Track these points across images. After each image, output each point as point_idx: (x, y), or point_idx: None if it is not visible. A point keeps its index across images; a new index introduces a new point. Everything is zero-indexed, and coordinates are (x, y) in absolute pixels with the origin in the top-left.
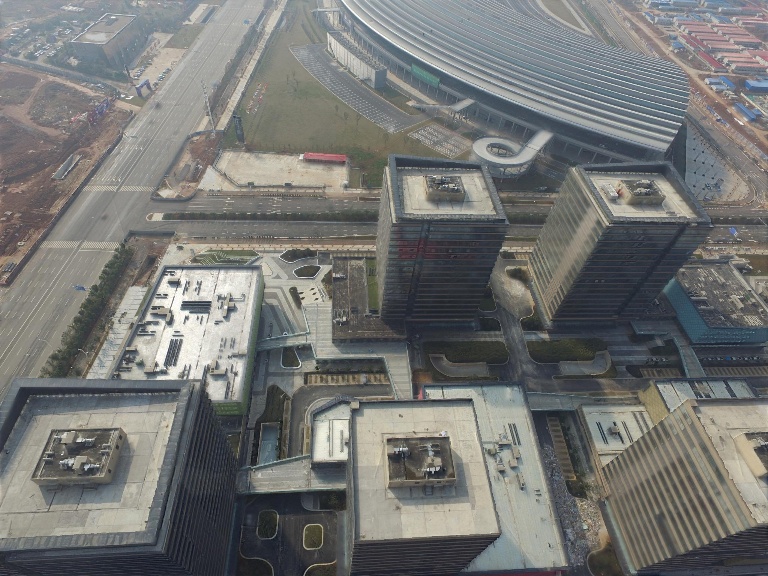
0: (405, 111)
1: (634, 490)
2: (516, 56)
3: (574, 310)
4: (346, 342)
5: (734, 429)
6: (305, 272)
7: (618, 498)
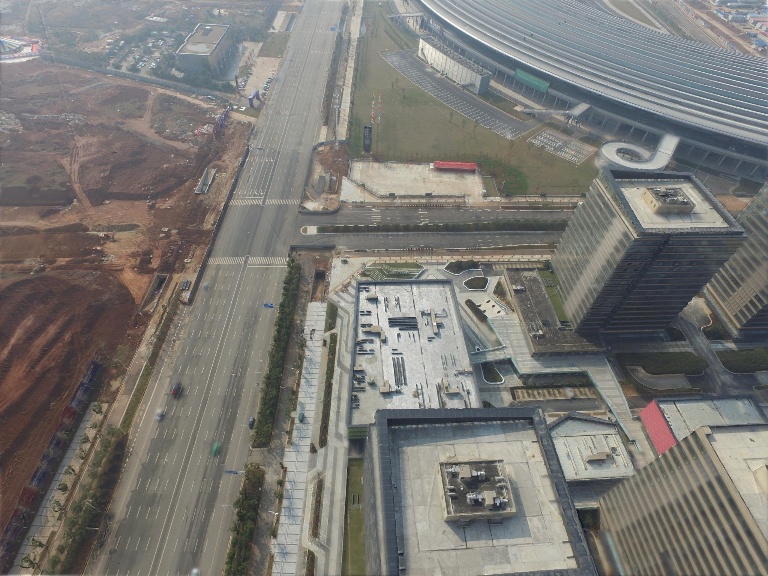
0: (516, 117)
1: None
2: (626, 59)
3: (766, 319)
4: (545, 356)
5: None
6: (475, 284)
7: None
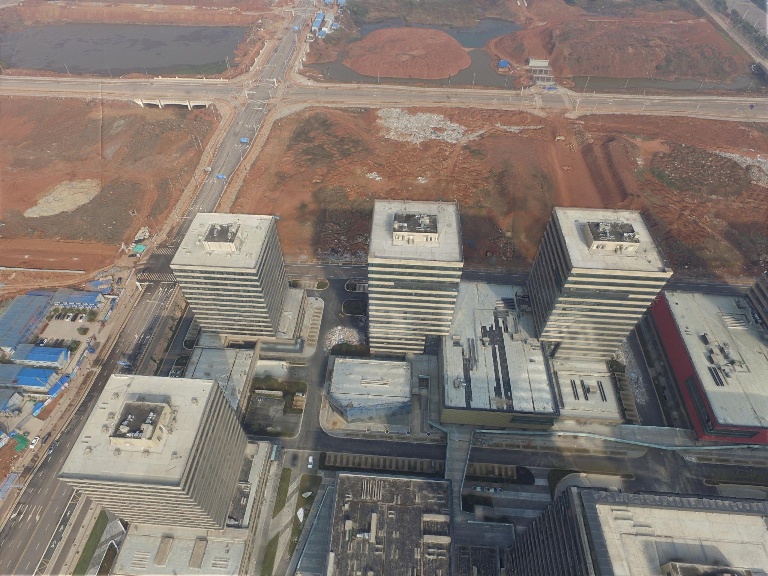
0: None
1: None
2: None
3: None
4: None
5: (632, 256)
6: None
7: None
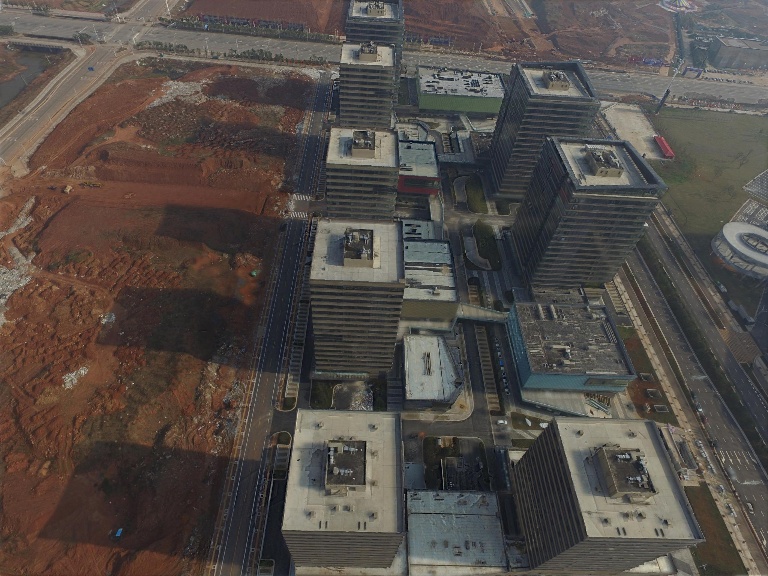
0: None
1: None
2: None
3: None
4: None
5: (380, 142)
6: None
7: None
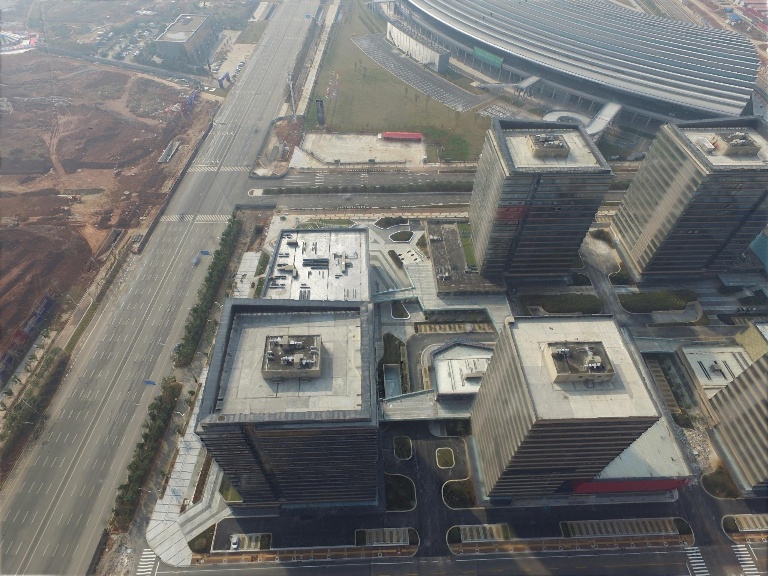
0: (470, 91)
1: (748, 412)
2: (578, 33)
3: (664, 263)
4: (450, 295)
5: None
6: (400, 237)
7: (729, 424)
